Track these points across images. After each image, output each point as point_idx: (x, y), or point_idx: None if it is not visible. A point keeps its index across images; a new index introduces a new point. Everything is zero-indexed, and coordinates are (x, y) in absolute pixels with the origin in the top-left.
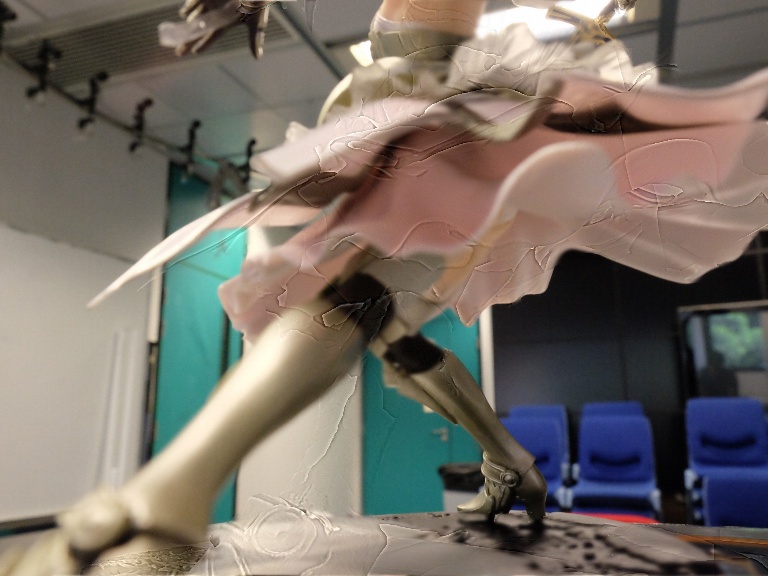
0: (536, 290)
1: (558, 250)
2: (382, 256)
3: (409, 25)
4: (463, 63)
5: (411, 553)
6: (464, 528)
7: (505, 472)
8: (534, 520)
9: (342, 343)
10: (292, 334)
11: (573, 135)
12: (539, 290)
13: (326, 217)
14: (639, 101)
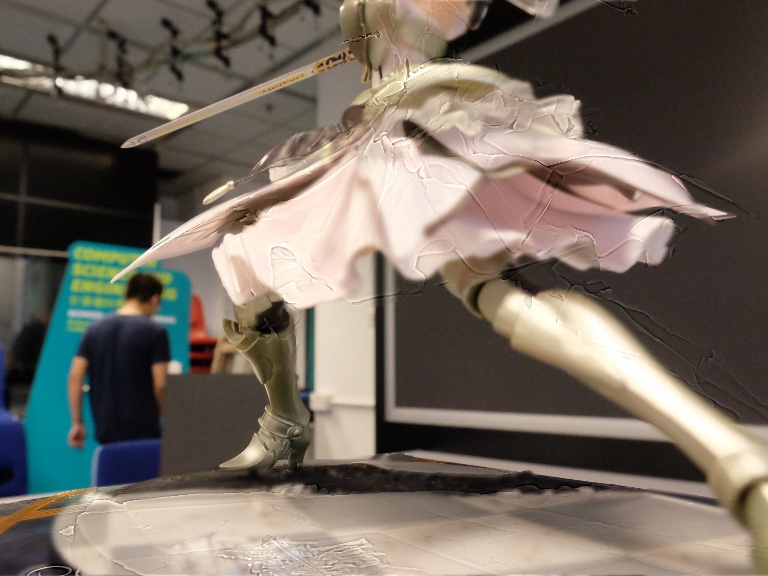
0: None
1: None
2: (599, 255)
3: (429, 3)
4: None
5: None
6: (237, 486)
7: (295, 426)
8: (293, 469)
9: (613, 325)
10: None
11: None
12: None
13: None
14: None
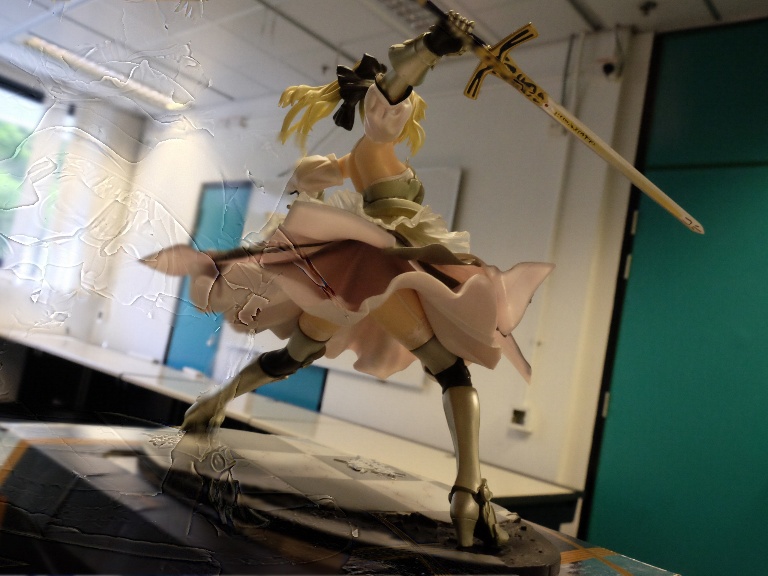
0: (208, 236)
1: (212, 170)
2: None
3: None
4: (69, 159)
5: (135, 471)
6: None
7: None
8: None
9: None
10: None
11: None
12: (209, 235)
13: (105, 260)
14: None
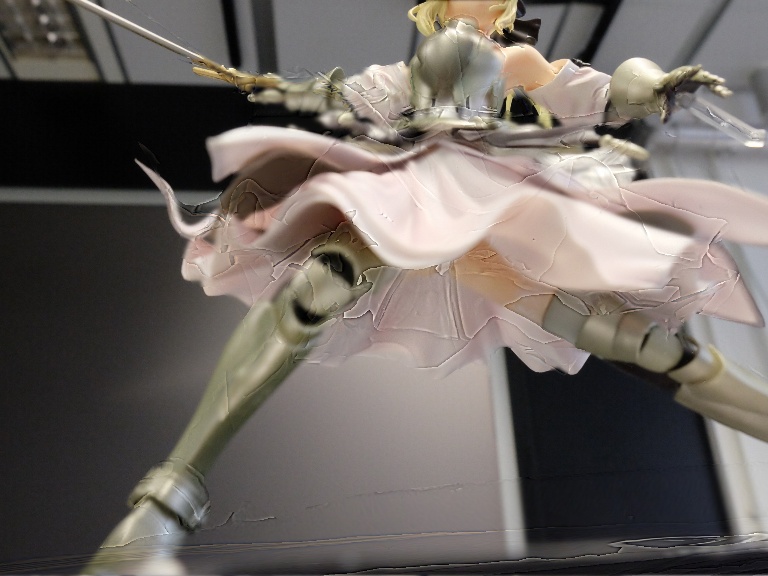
0: None
1: None
2: None
3: None
4: None
5: (522, 574)
6: None
7: None
8: None
9: None
10: (669, 263)
11: None
12: None
13: None
14: (594, 313)
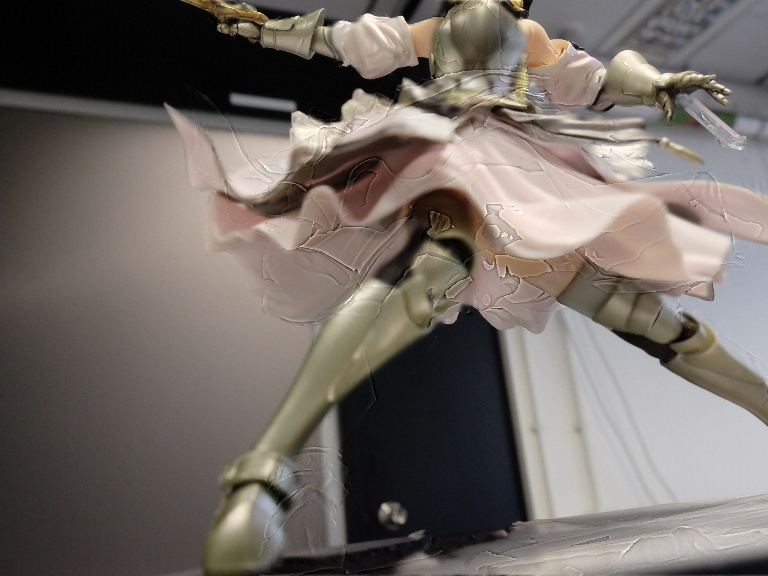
0: None
1: None
2: None
3: None
4: None
5: None
6: None
7: None
8: None
9: None
10: None
11: (594, 282)
12: None
13: None
14: None
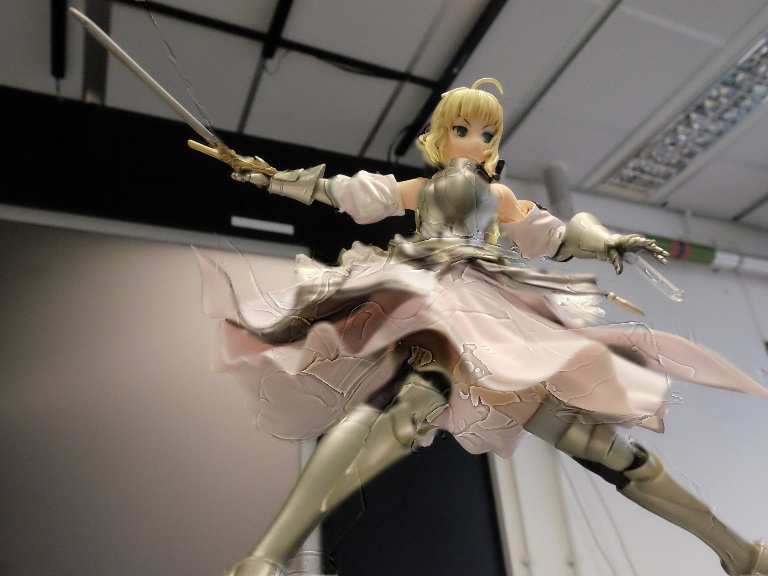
0: None
1: None
2: None
3: None
4: None
5: None
6: None
7: None
8: None
9: None
10: None
11: None
12: None
13: None
14: None
